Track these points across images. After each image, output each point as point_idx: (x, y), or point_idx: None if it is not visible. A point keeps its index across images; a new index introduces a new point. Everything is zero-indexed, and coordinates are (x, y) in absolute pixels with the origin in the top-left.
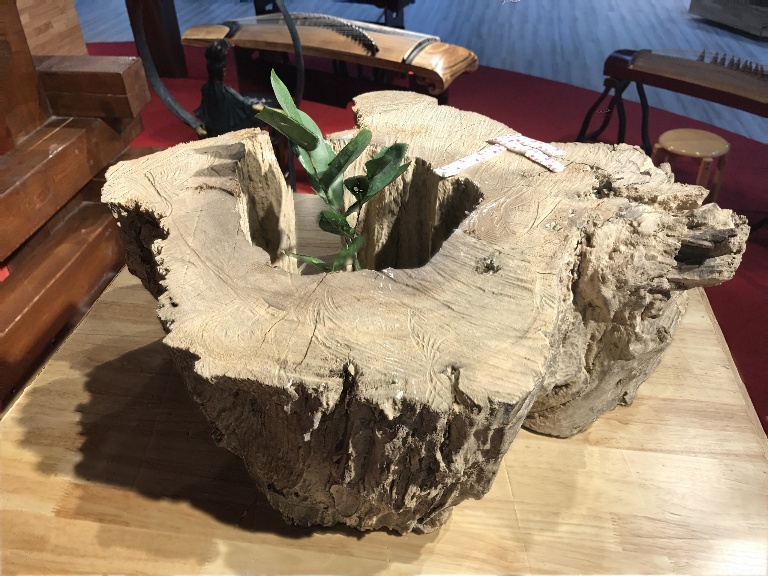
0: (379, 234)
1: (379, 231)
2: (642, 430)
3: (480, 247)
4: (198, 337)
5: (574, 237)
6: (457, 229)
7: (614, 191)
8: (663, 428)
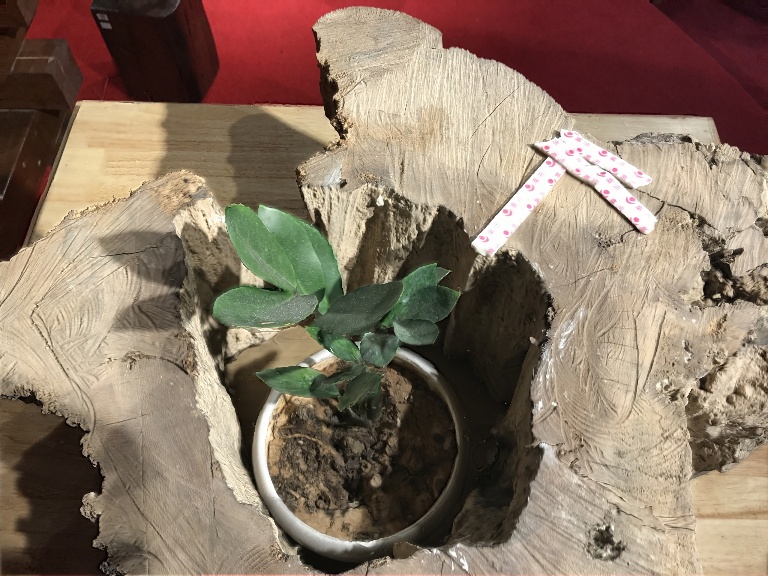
0: (380, 278)
1: (380, 275)
2: (697, 486)
3: (588, 498)
4: None
5: (688, 388)
6: (546, 449)
7: (733, 280)
8: (720, 480)
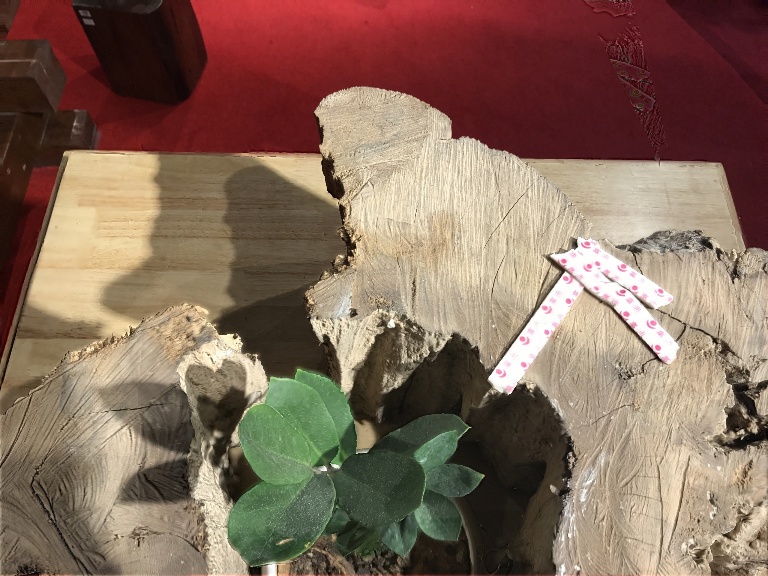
0: (389, 383)
1: (389, 381)
2: None
3: None
4: None
5: (713, 540)
6: None
7: (758, 417)
8: None
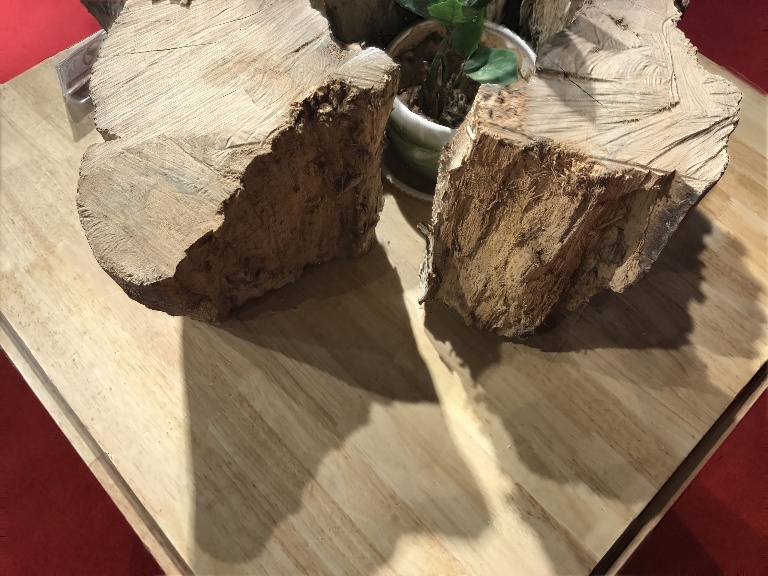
0: None
1: None
2: None
3: None
4: None
5: None
6: None
7: None
8: None
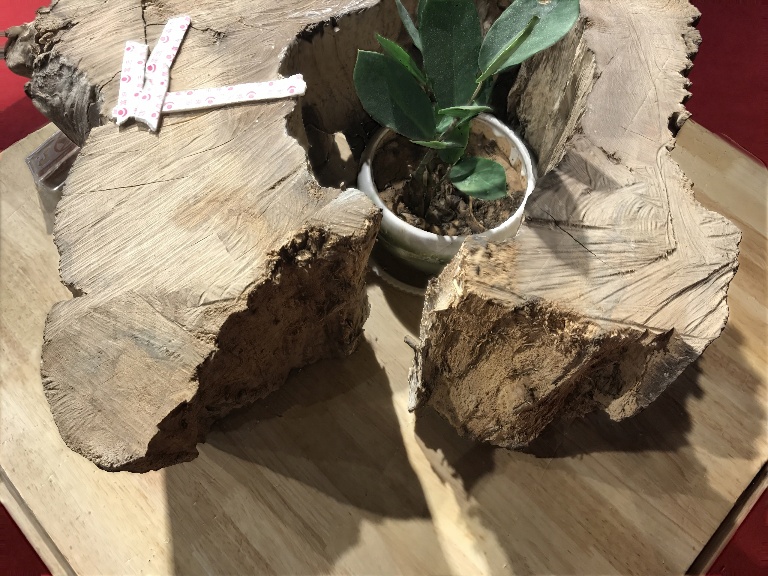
0: None
1: None
2: None
3: None
4: (673, 2)
5: None
6: None
7: None
8: None
